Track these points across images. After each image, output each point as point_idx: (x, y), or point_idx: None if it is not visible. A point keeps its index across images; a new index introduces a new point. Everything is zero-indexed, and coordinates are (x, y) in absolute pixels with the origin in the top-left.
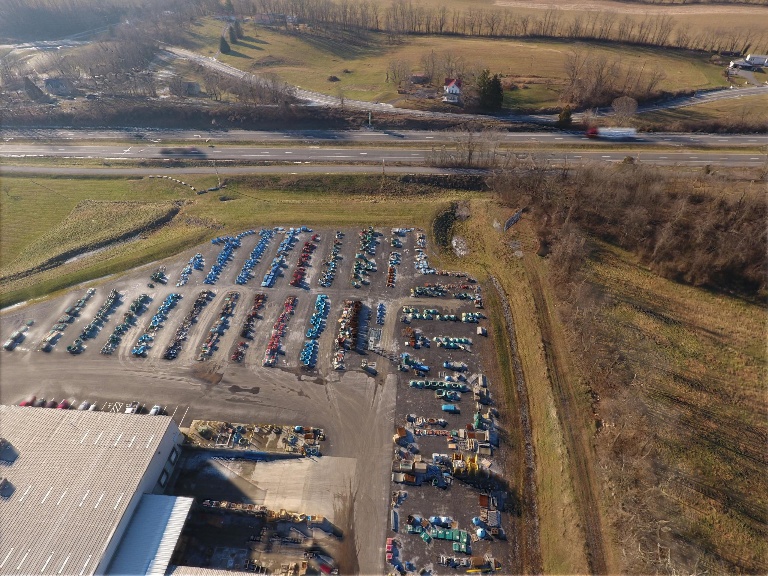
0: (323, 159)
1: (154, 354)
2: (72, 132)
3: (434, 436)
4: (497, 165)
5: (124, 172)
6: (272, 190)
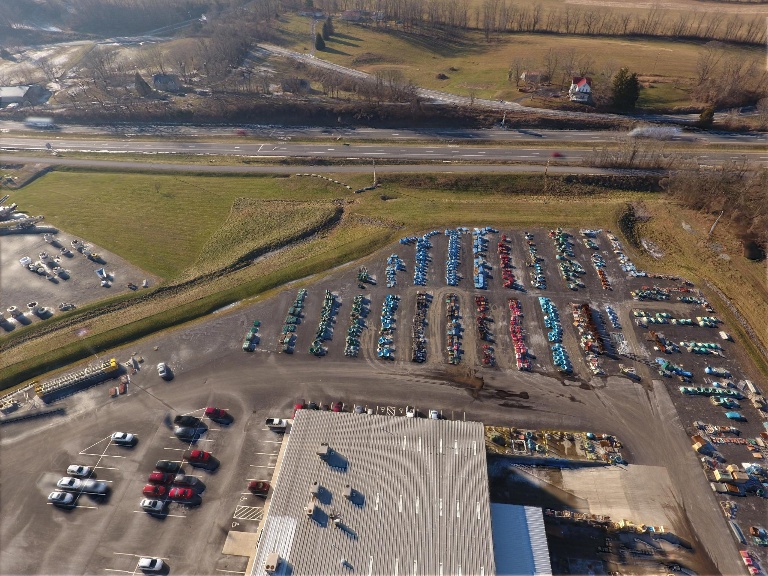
0: (469, 158)
1: (401, 357)
2: (194, 129)
3: (733, 444)
4: (659, 166)
5: (268, 170)
6: (430, 189)
